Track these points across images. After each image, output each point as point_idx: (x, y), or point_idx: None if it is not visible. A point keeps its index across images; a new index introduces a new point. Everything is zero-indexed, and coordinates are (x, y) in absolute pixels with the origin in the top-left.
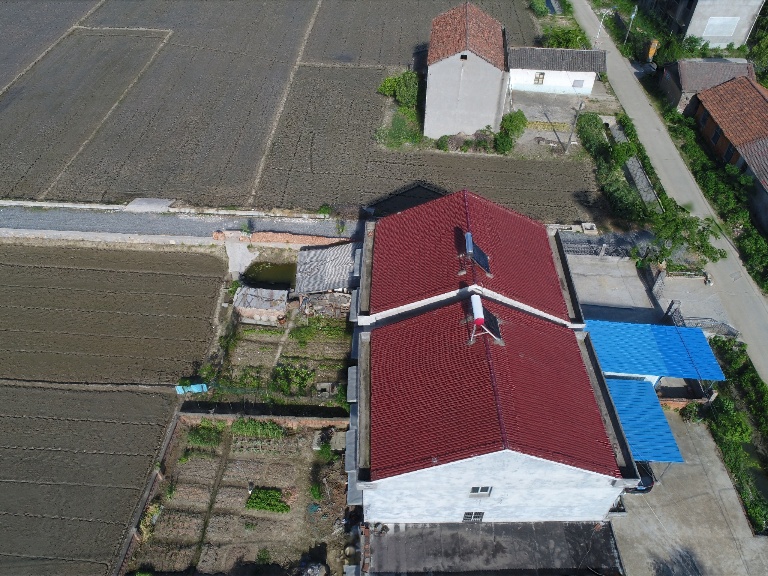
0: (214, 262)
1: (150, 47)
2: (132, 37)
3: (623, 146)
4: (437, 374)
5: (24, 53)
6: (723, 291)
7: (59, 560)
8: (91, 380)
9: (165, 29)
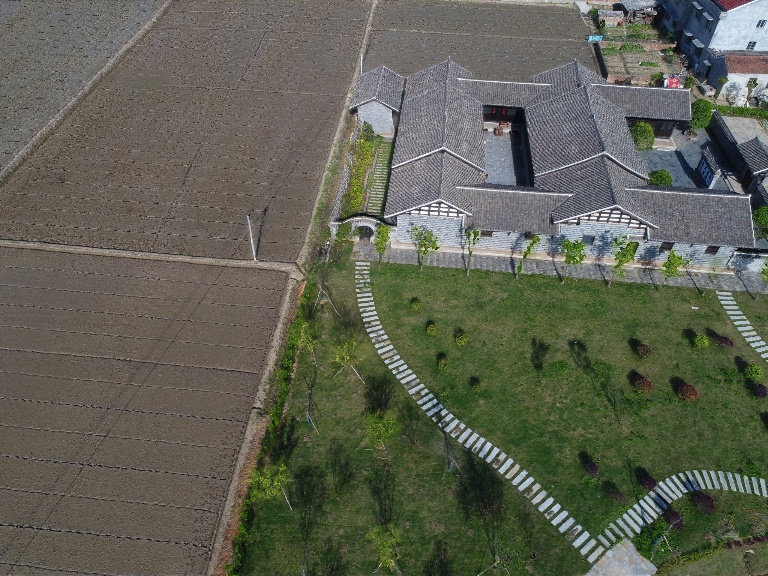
0: (570, 10)
1: None
2: None
3: None
4: None
5: None
6: None
7: None
8: None
9: None
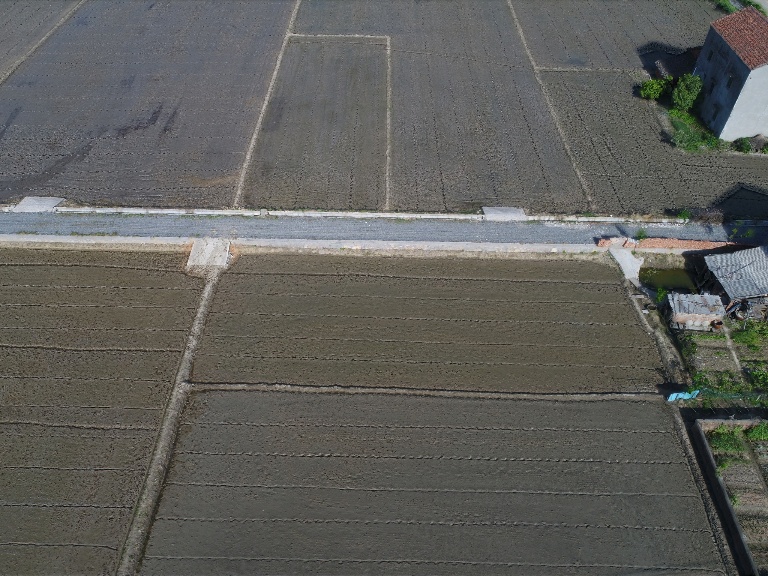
0: (602, 269)
1: (378, 54)
2: (353, 44)
3: None
4: None
5: (258, 62)
6: None
7: (673, 569)
8: (571, 390)
9: (381, 35)
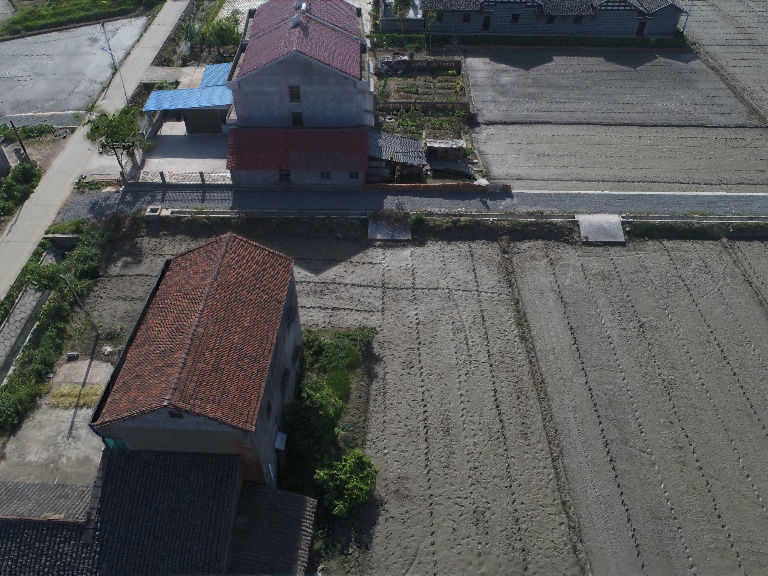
0: None
1: None
2: None
3: (43, 272)
4: (327, 7)
5: None
6: (76, 173)
7: None
8: (534, 125)
9: None
